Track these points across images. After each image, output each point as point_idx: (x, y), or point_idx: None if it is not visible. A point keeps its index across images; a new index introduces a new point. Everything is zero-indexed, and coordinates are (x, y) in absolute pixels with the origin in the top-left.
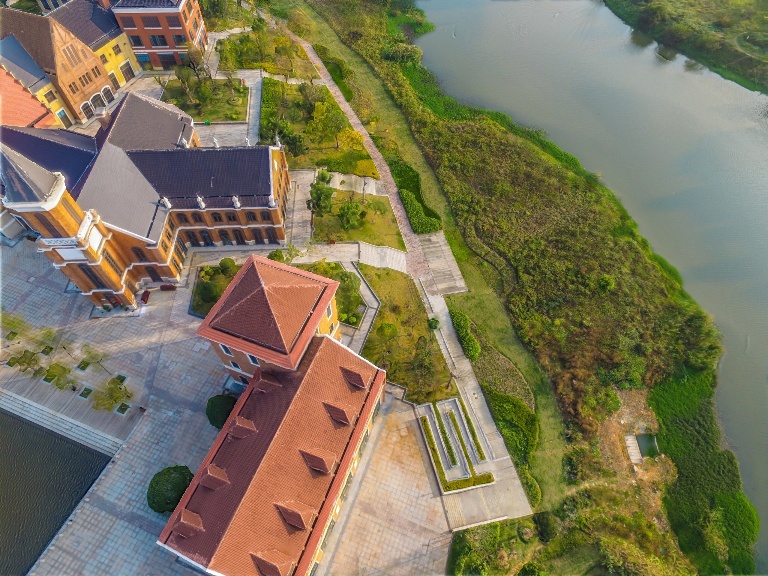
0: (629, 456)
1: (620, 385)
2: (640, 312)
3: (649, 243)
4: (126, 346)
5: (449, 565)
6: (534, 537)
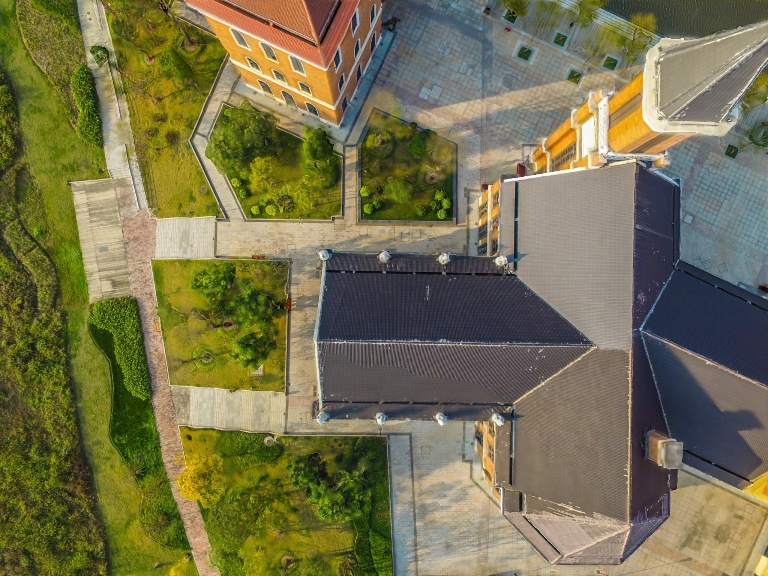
0: None
1: None
2: None
3: None
4: (528, 100)
5: None
6: None
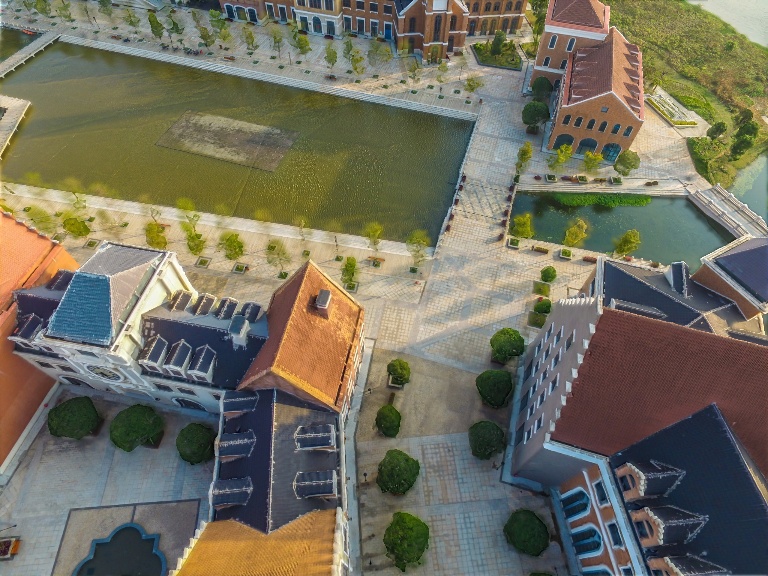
0: (765, 122)
1: (751, 94)
2: (752, 65)
3: (746, 36)
4: (450, 79)
5: (690, 148)
6: (728, 143)
